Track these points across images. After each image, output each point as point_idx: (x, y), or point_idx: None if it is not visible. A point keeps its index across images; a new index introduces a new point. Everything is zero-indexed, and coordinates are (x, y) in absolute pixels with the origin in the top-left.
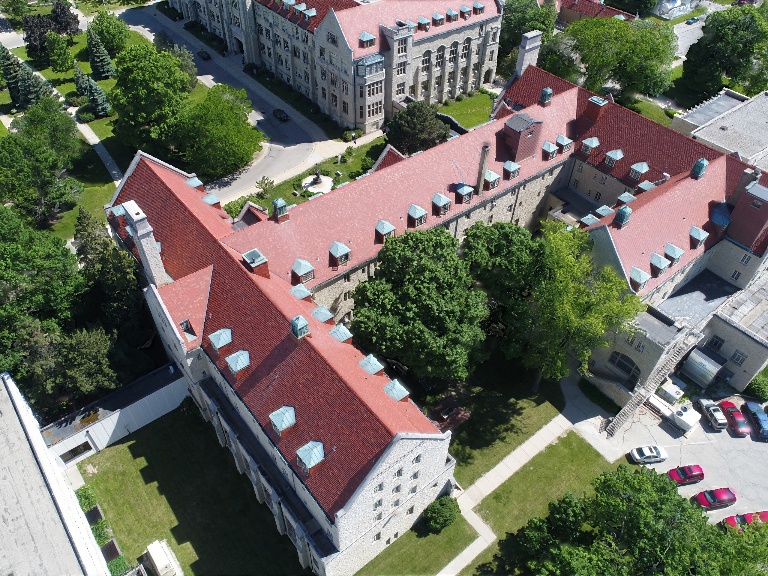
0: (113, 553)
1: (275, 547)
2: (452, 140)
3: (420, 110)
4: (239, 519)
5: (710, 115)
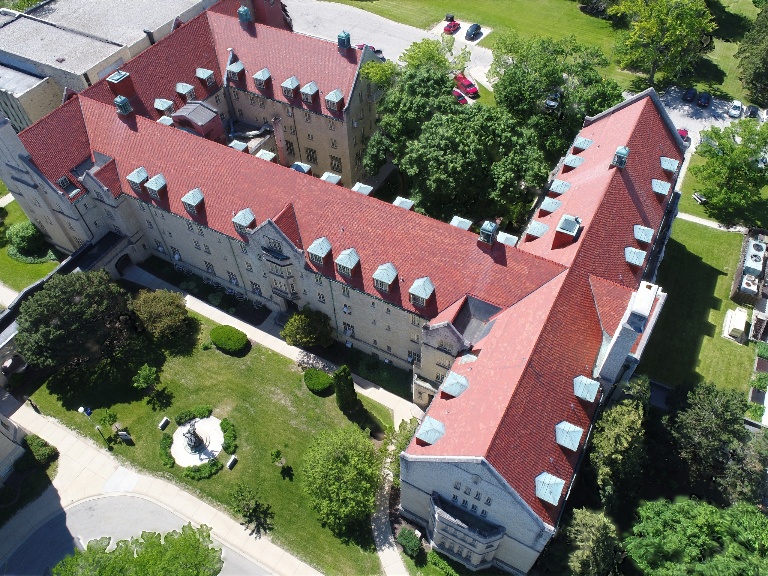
0: (761, 364)
1: (662, 272)
2: (255, 157)
3: (69, 285)
4: (666, 301)
5: (7, 80)
